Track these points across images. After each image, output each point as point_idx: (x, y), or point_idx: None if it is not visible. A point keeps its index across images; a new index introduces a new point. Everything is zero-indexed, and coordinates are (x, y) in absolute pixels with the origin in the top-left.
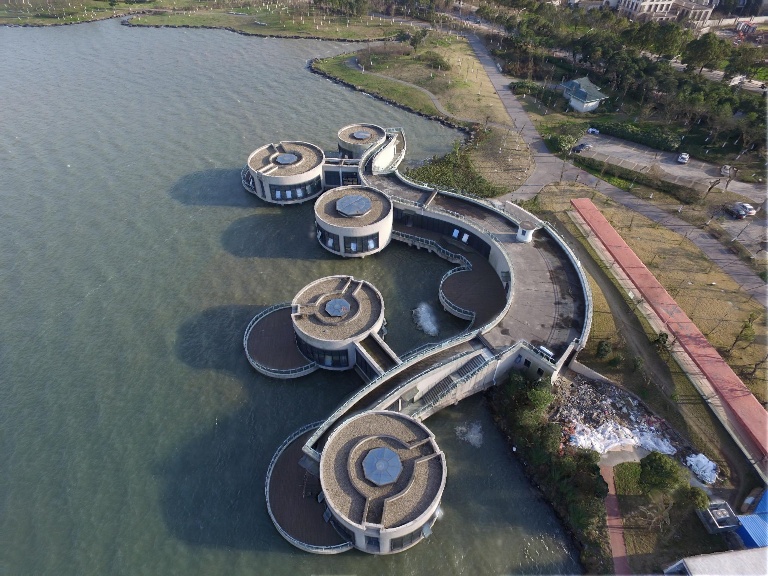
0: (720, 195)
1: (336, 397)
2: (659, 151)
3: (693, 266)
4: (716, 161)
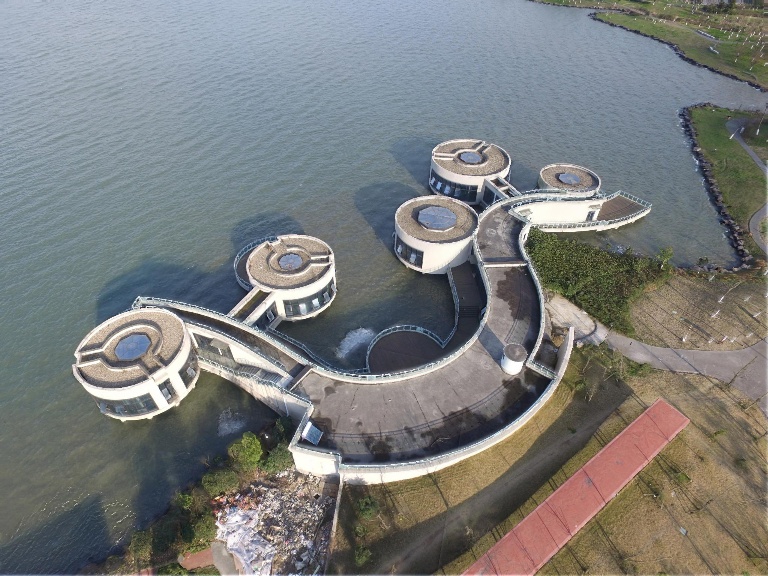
0: None
1: (224, 312)
2: None
3: None
4: None
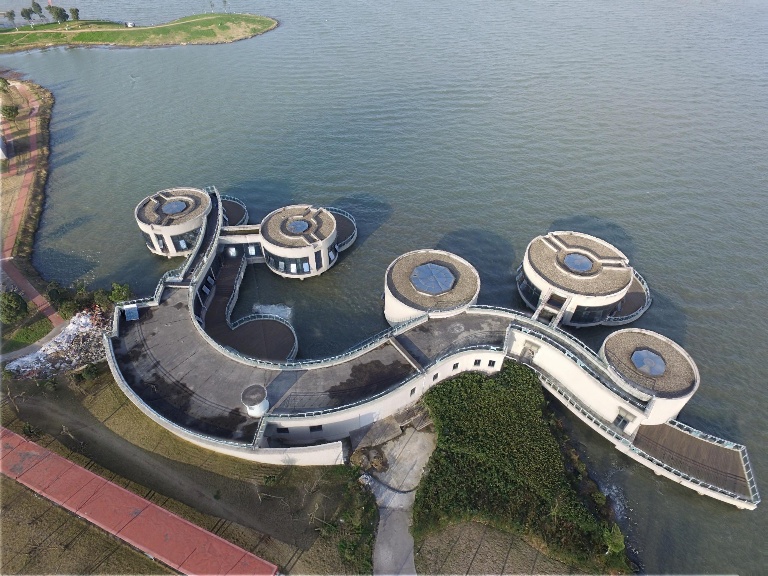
0: None
1: None
2: None
3: None
4: None
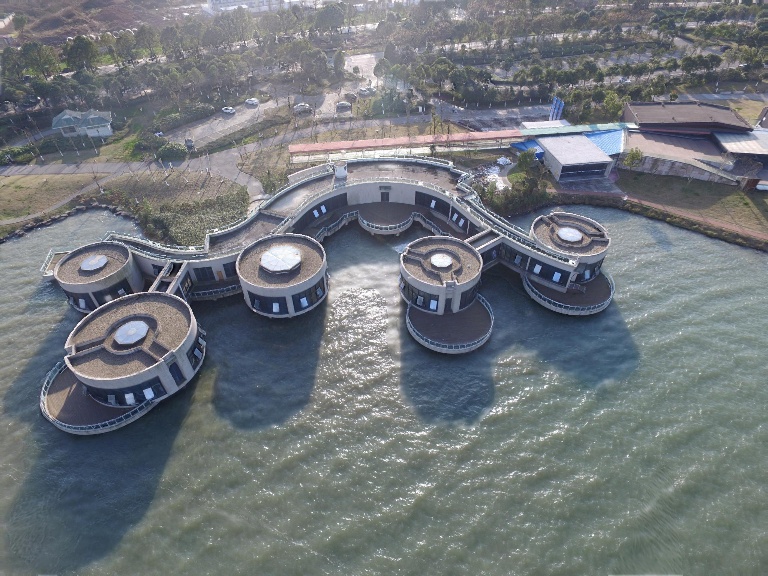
0: (281, 111)
1: (506, 281)
2: (210, 117)
3: (359, 133)
4: (238, 102)
